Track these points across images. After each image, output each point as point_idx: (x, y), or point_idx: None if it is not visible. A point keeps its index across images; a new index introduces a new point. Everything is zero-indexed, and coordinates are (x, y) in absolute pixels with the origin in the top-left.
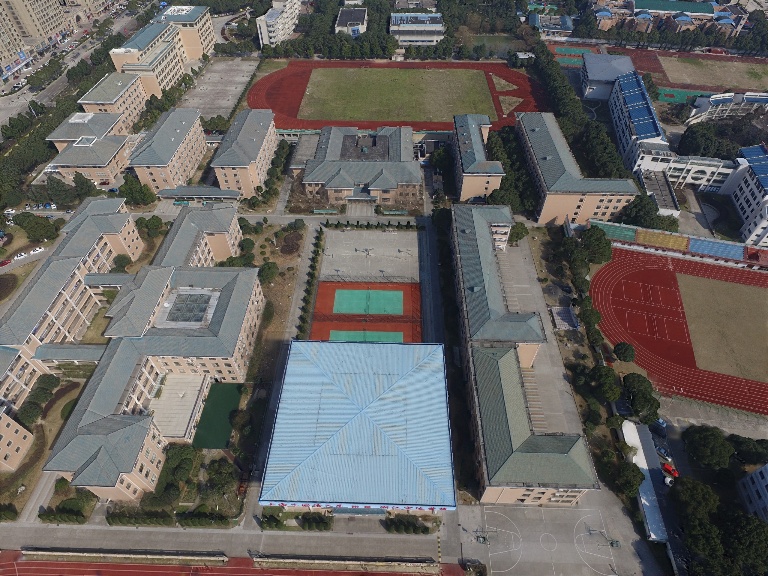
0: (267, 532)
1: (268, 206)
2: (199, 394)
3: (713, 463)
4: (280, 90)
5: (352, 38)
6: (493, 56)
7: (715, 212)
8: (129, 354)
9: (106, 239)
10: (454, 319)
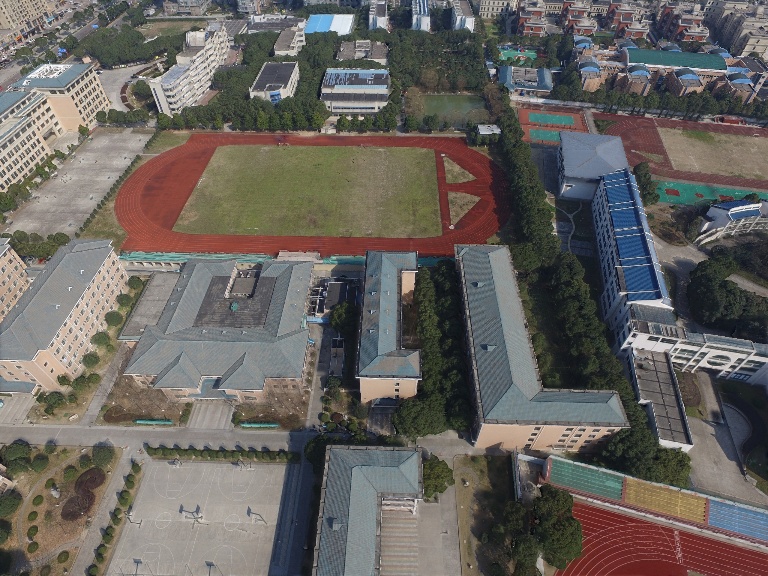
0: None
1: (76, 406)
2: None
3: None
4: (165, 181)
5: (271, 105)
6: (449, 128)
7: (744, 423)
8: None
9: None
10: None
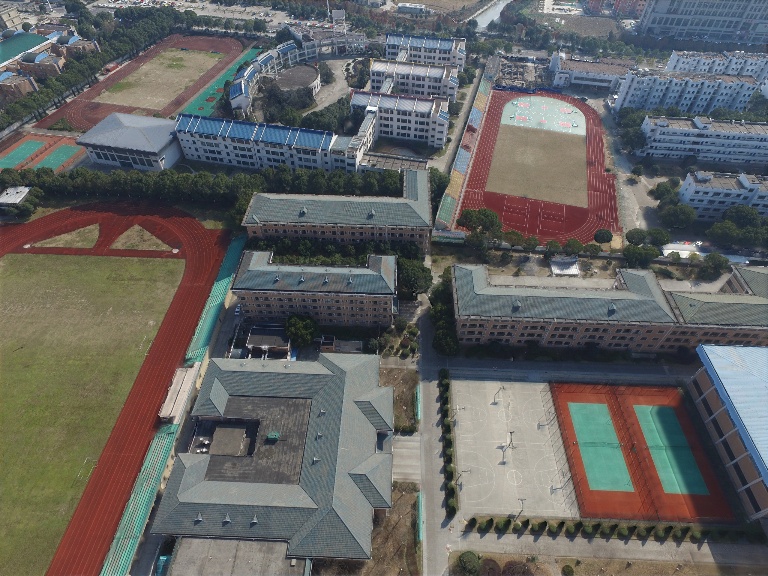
0: None
1: None
2: None
3: None
4: None
5: None
6: None
7: (402, 149)
8: None
9: None
10: None
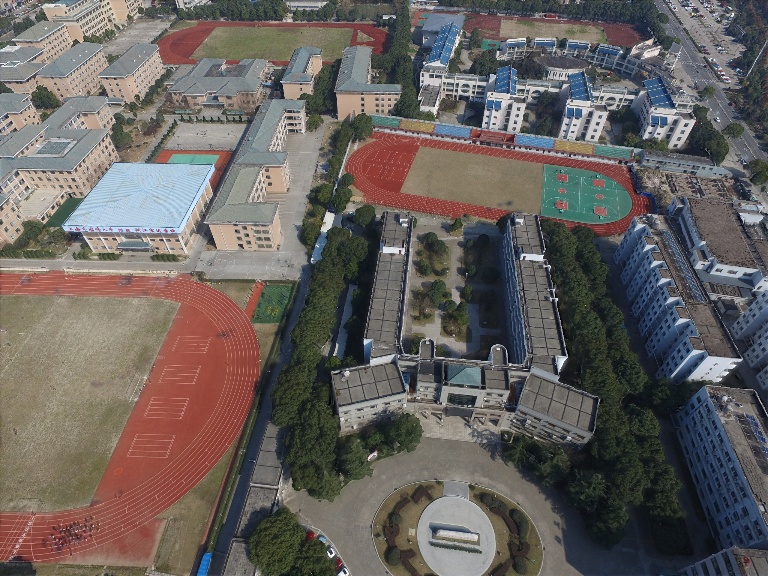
0: (78, 261)
1: (144, 110)
2: (53, 198)
3: (360, 222)
4: (183, 41)
5: (251, 3)
6: (366, 19)
7: (473, 114)
8: (4, 166)
9: (11, 119)
10: None
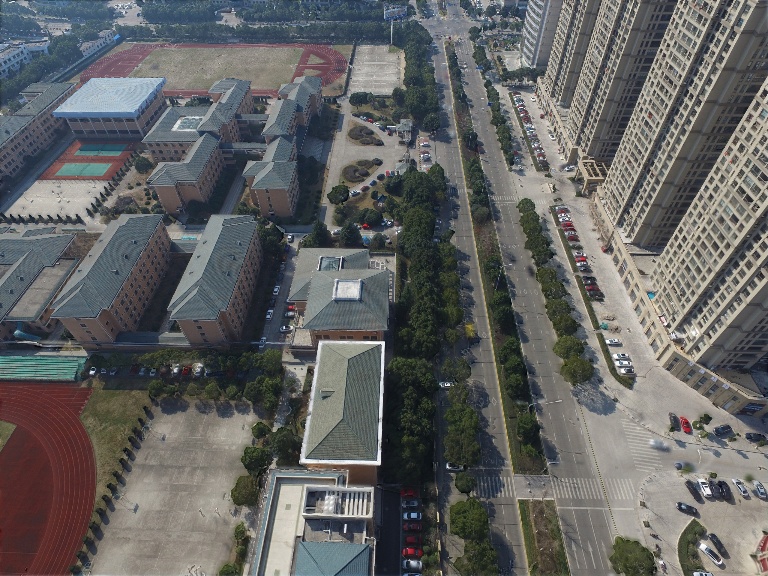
0: None
1: None
2: None
3: None
4: None
5: None
6: None
7: None
8: None
9: None
10: None
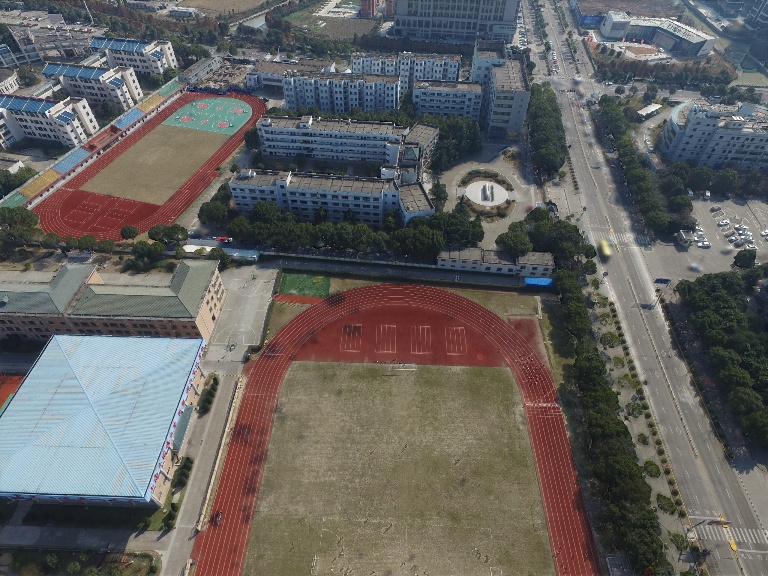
0: (177, 522)
1: None
2: None
3: (223, 213)
4: None
5: None
6: None
7: (36, 150)
8: None
9: None
10: (24, 344)
